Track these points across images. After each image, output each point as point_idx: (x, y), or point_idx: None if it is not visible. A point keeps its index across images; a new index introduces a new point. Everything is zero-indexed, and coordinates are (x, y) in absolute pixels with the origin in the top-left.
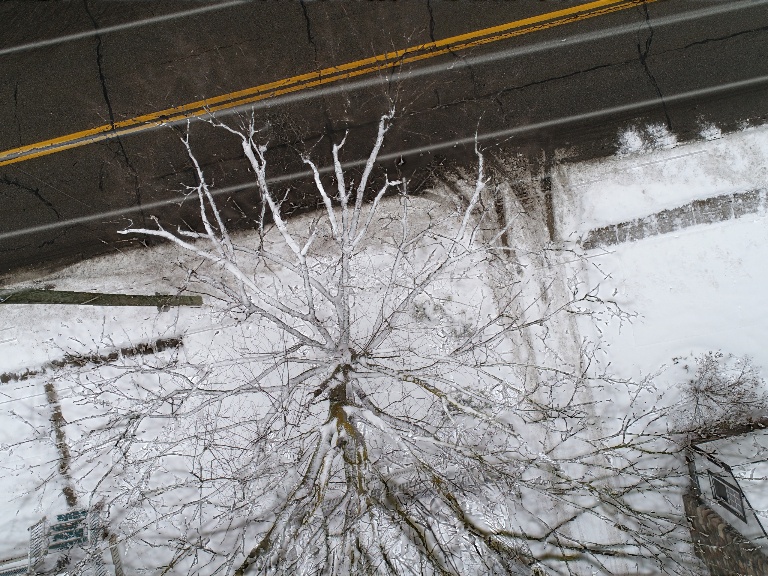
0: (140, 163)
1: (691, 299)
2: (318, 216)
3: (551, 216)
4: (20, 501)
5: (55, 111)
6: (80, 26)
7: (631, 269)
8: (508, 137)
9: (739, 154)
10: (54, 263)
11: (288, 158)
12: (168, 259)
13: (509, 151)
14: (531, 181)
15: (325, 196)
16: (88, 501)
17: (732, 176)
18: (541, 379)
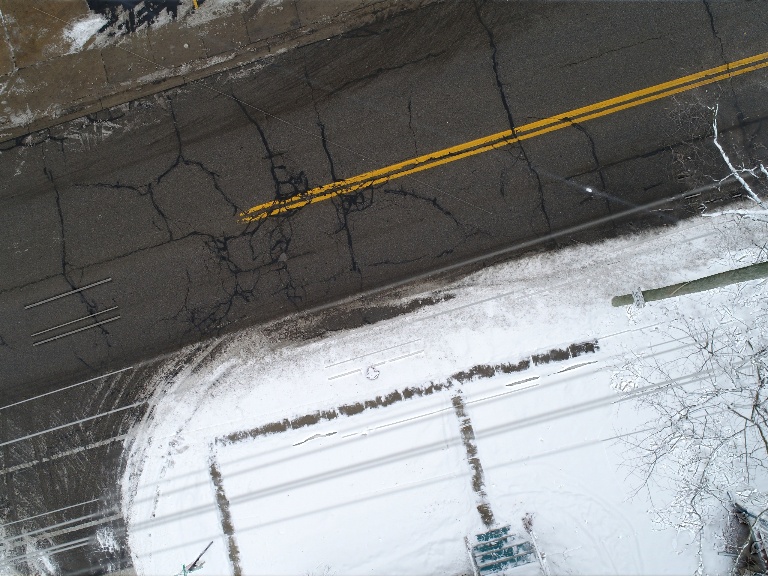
0: (543, 166)
1: None
2: None
3: None
4: (438, 521)
5: (452, 120)
6: (474, 36)
7: None
8: None
9: None
10: (454, 272)
11: (699, 152)
12: (575, 261)
13: None
14: None
15: None
16: (509, 518)
17: None
18: None
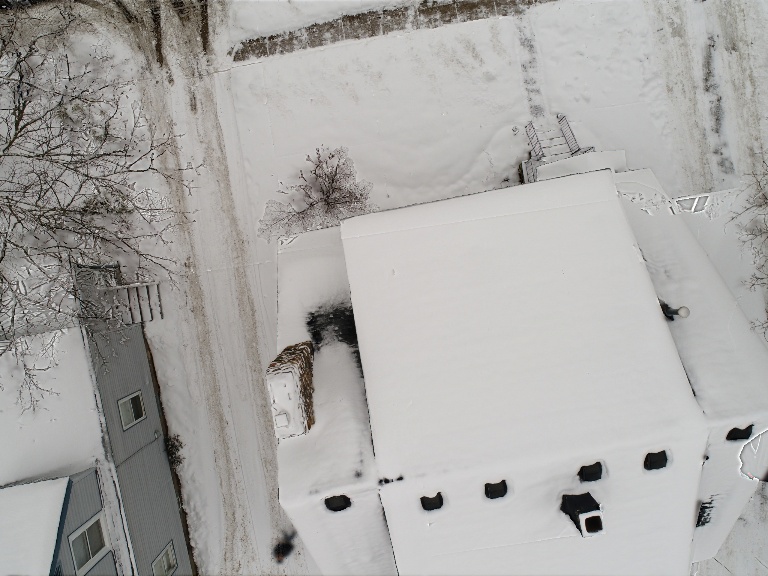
0: None
1: (331, 111)
2: None
3: (206, 27)
4: None
5: None
6: None
7: (273, 79)
8: None
9: None
10: None
11: None
12: None
13: None
14: None
15: None
16: None
17: None
18: (185, 189)
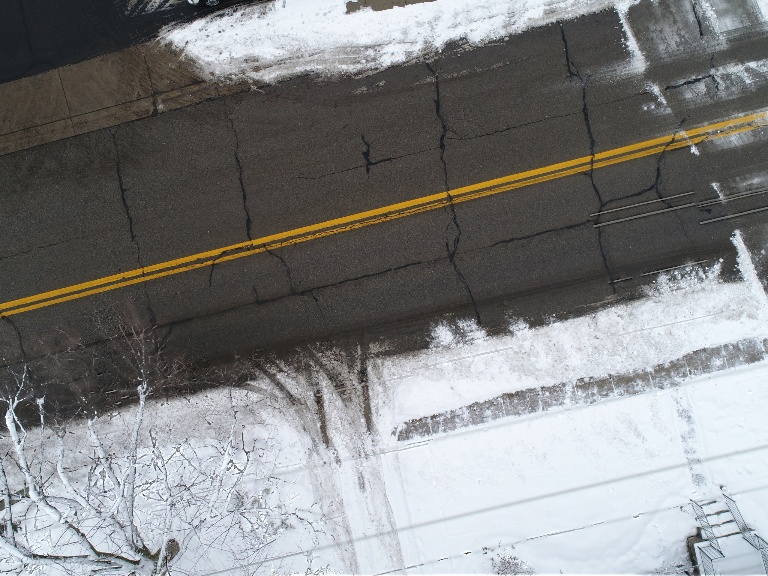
0: None
1: (499, 491)
2: (146, 407)
3: (368, 407)
4: None
5: None
6: None
7: (441, 463)
8: (325, 332)
9: (543, 351)
10: None
11: (116, 351)
12: (6, 446)
13: (326, 345)
14: (348, 373)
15: (67, 484)
16: None
17: (536, 373)
18: (360, 565)
